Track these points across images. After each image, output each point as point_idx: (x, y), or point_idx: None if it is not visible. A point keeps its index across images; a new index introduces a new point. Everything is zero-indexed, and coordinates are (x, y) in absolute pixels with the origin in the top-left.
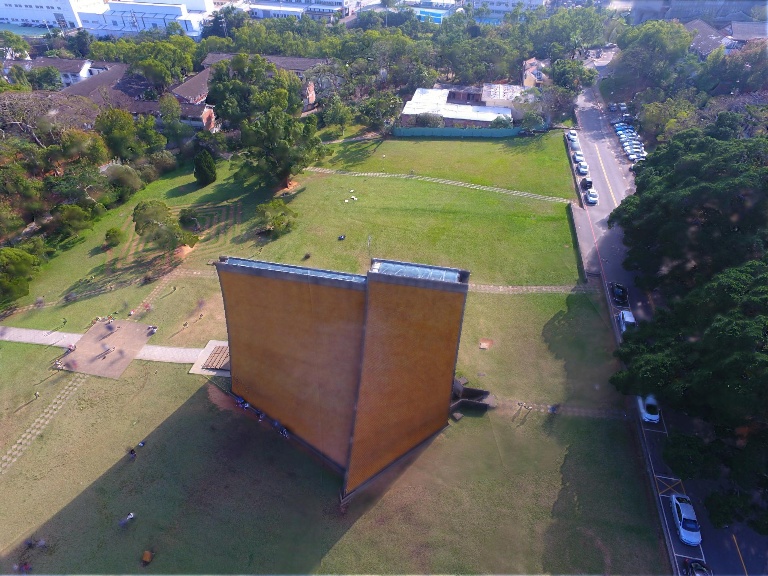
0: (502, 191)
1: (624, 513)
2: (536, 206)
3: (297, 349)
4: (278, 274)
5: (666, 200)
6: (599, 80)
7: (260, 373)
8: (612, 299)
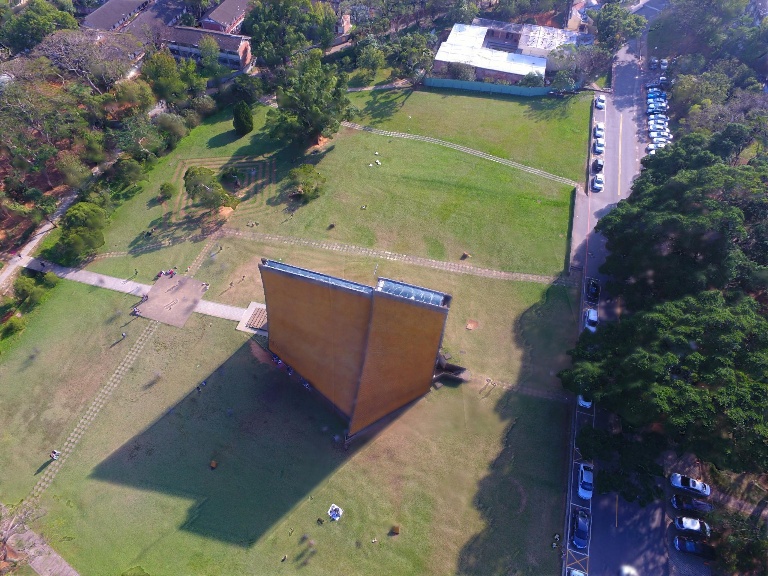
0: (517, 166)
1: (544, 471)
2: (544, 187)
3: (319, 330)
4: (306, 279)
5: (645, 220)
6: (645, 32)
7: (290, 341)
8: (586, 295)
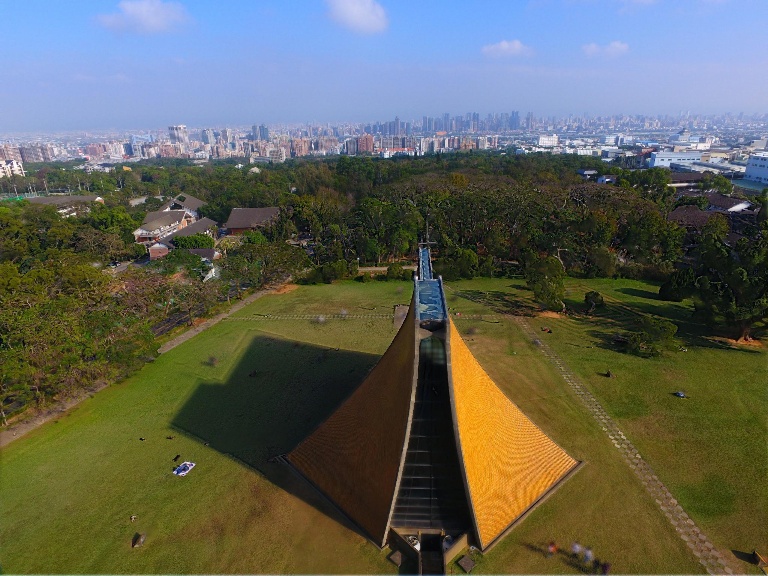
0: None
1: None
2: None
3: None
4: None
5: None
6: None
7: None
8: None
